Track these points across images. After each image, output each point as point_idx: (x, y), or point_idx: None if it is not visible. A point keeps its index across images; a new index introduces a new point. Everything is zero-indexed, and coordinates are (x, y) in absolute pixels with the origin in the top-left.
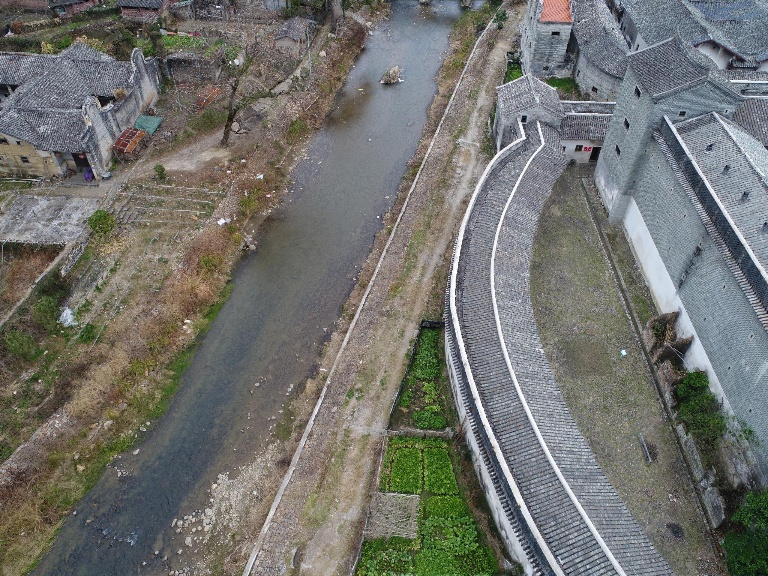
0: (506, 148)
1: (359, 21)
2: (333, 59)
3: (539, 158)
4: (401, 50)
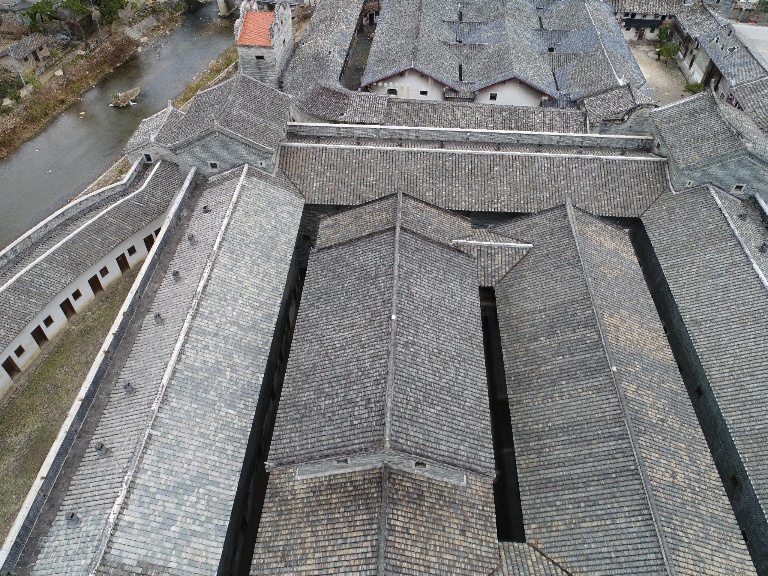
0: (91, 194)
1: (132, 36)
2: (70, 79)
3: (125, 206)
4: (158, 69)
